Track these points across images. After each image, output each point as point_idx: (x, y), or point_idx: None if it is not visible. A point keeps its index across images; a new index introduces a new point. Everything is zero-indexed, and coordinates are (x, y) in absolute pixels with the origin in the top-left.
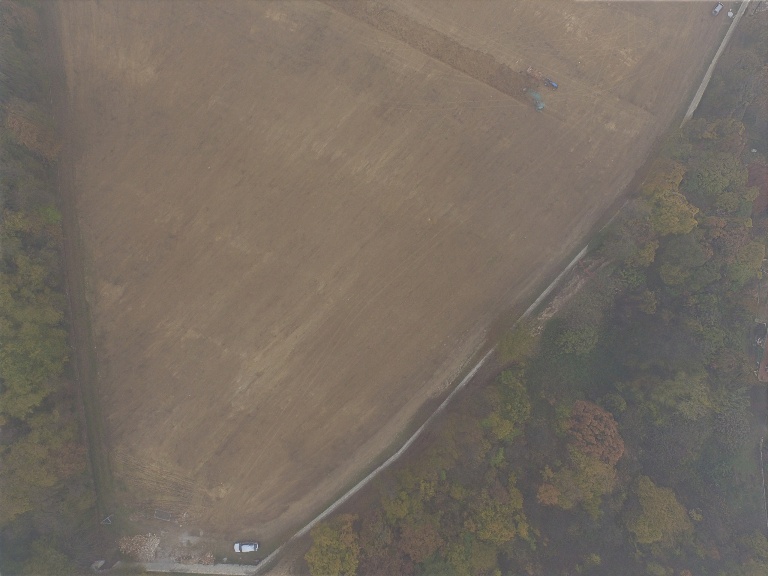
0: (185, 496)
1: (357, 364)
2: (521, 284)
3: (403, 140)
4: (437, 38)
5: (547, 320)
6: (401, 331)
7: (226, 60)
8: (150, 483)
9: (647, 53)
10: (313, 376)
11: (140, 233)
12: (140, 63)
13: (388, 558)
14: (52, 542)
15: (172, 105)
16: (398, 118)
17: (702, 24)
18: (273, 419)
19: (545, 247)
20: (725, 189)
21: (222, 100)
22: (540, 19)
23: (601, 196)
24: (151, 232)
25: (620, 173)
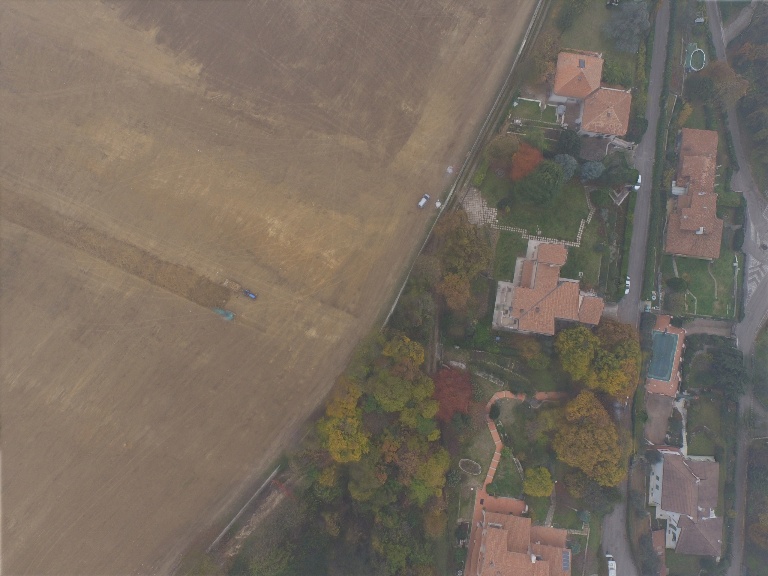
0: None
1: None
2: (218, 504)
3: (100, 363)
4: (134, 255)
5: (245, 539)
6: (94, 563)
7: None
8: None
9: (351, 253)
10: None
11: None
12: None
13: None
14: None
15: None
16: (95, 340)
17: (408, 217)
18: None
19: (242, 464)
20: (404, 407)
21: None
22: (242, 225)
23: (300, 407)
24: None
25: (320, 381)
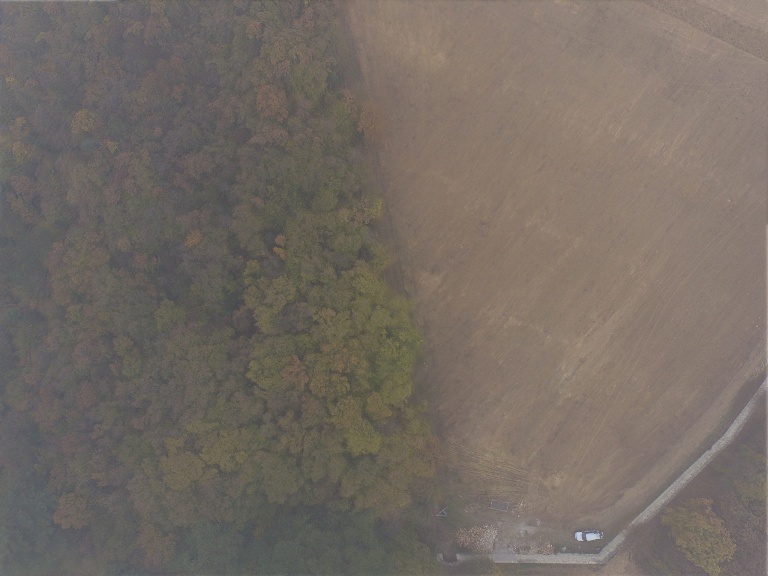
0: (521, 486)
1: (675, 348)
2: None
3: (695, 121)
4: (719, 18)
5: None
6: (714, 313)
7: (514, 44)
8: (485, 473)
9: None
10: (634, 361)
11: (452, 220)
12: (430, 48)
13: (757, 541)
14: (413, 535)
15: (467, 90)
16: (687, 99)
17: None
18: (600, 405)
19: None
20: None
21: (516, 84)
22: None
23: None
24: (462, 219)
25: None
